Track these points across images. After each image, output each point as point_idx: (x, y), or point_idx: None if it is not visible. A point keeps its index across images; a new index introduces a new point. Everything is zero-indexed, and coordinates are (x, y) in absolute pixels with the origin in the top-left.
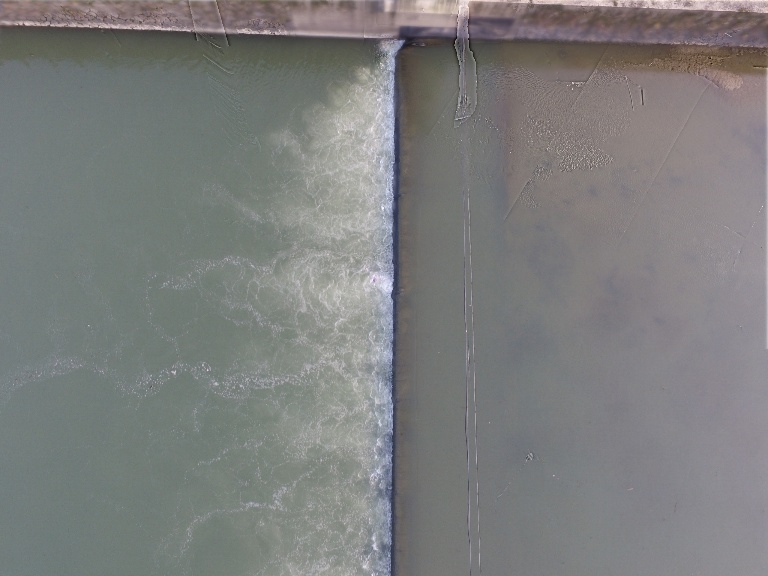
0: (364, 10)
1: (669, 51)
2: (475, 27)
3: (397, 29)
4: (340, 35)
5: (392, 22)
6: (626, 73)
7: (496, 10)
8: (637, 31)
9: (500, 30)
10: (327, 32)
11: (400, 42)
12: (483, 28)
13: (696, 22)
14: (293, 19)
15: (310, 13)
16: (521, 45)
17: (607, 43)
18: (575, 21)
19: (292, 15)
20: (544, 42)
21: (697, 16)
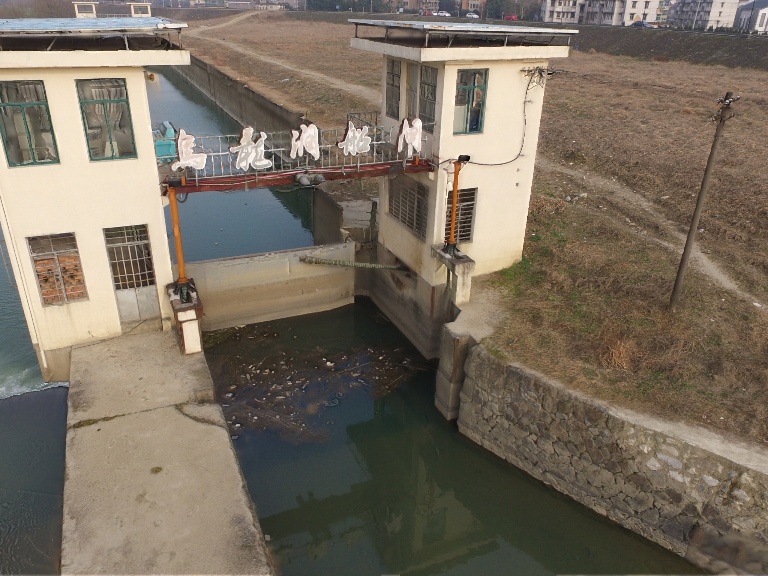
0: None
1: None
2: None
3: None
4: None
5: None
6: None
7: None
8: None
9: None
10: None
11: None
12: None
13: None
14: None
15: None
16: None
17: None
18: None
19: None
20: None
21: None
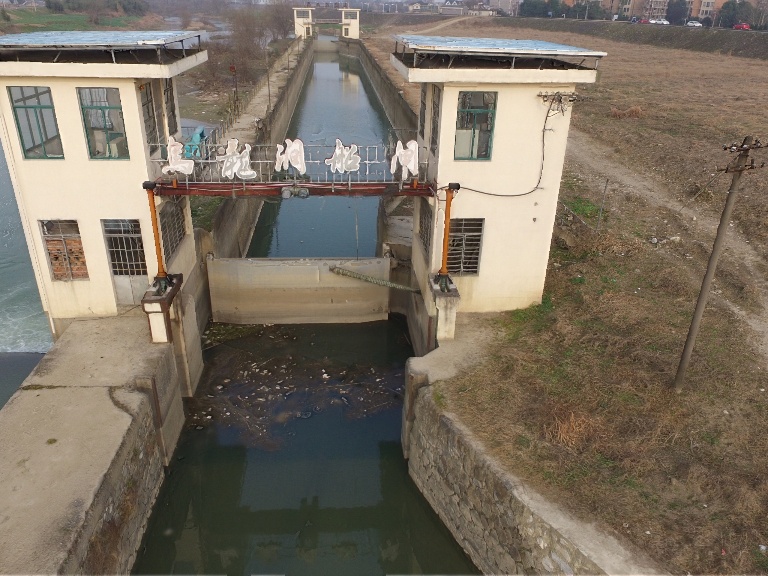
0: None
1: None
2: None
3: None
4: None
5: None
6: None
7: None
8: None
9: None
10: None
11: None
12: None
13: None
14: None
15: None
16: None
17: None
18: None
19: None
20: None
21: None
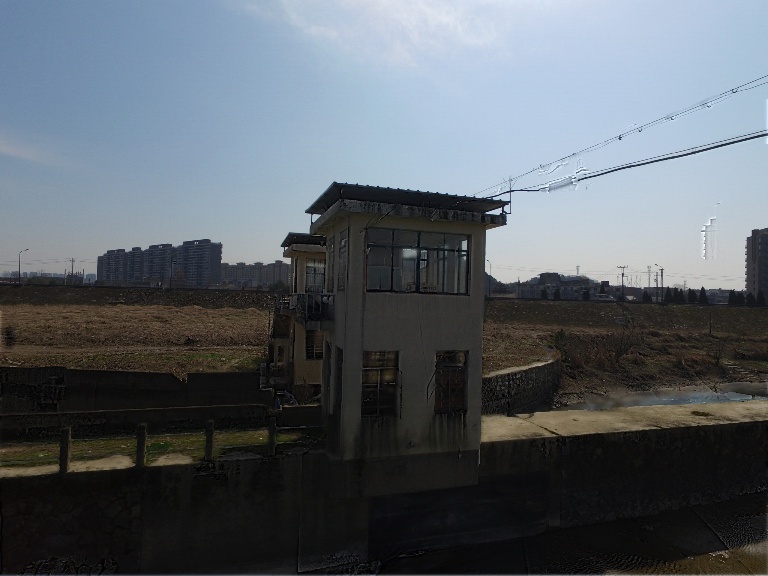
0: (299, 491)
1: (767, 497)
2: (495, 502)
3: (363, 533)
4: (245, 575)
5: (358, 489)
6: (761, 526)
7: (517, 457)
8: (708, 473)
9: (535, 502)
10: (216, 571)
11: (372, 569)
12: (508, 502)
13: (759, 443)
14: (142, 544)
15: (185, 518)
16: (577, 531)
17: (686, 506)
18: (628, 464)
19: (142, 531)
20: (605, 521)
21: (754, 433)
